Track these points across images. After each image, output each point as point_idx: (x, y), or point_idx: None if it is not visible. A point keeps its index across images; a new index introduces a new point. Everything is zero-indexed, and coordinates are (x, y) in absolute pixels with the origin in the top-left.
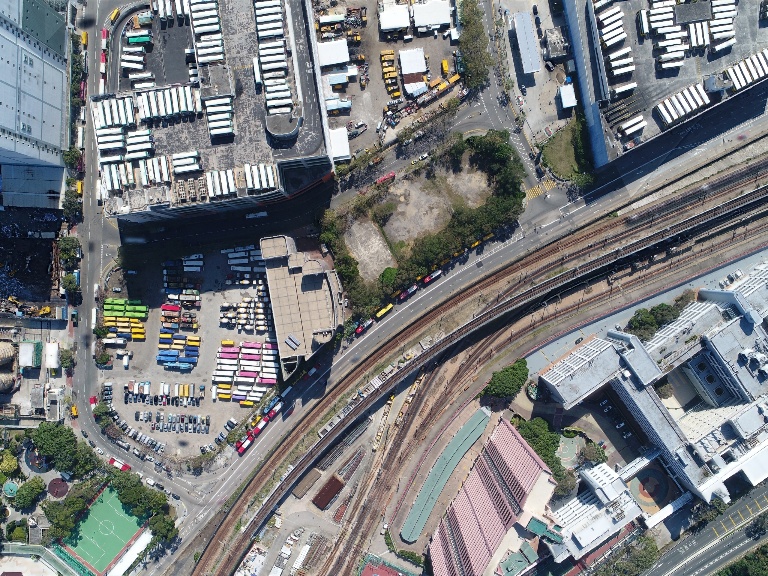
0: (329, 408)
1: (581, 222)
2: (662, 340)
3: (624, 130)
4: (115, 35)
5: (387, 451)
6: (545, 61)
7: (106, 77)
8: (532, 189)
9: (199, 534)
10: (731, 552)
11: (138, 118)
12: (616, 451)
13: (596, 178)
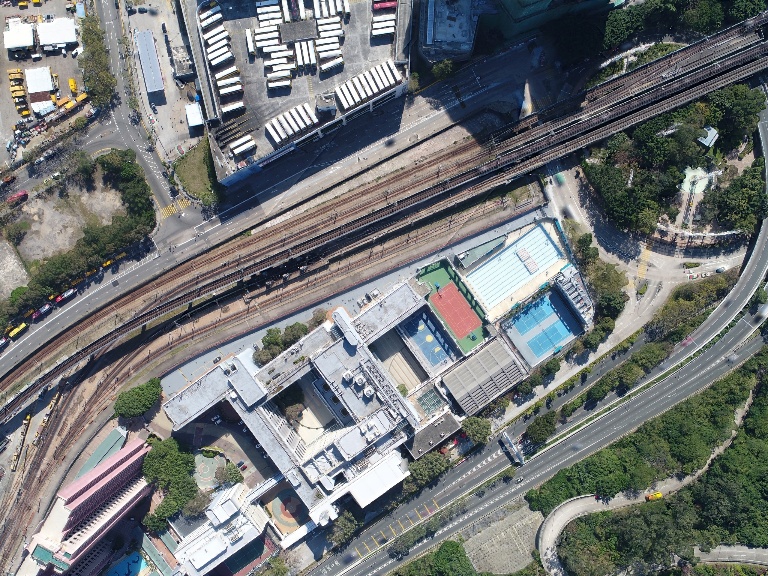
0: None
1: (217, 241)
2: (271, 361)
3: (233, 149)
4: None
5: (27, 471)
6: (176, 79)
7: None
8: (166, 208)
9: None
10: (374, 573)
11: None
12: (257, 471)
13: (221, 197)
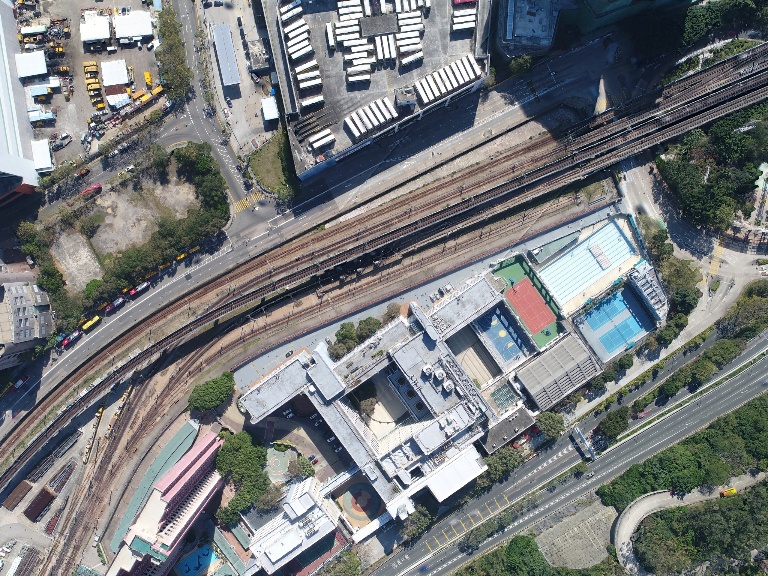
0: (39, 420)
1: (290, 235)
2: (349, 355)
3: (312, 143)
4: None
5: (98, 463)
6: (251, 73)
7: None
8: (240, 201)
9: None
10: (444, 567)
11: None
12: (328, 465)
13: (297, 191)
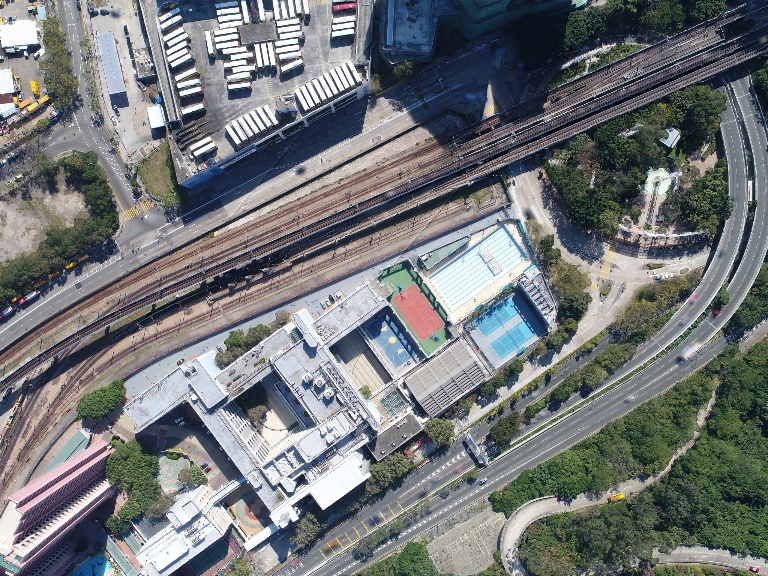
0: None
1: (180, 243)
2: (232, 363)
3: (193, 151)
4: None
5: None
6: (138, 81)
7: None
8: (129, 210)
9: None
10: (339, 574)
11: None
12: (221, 473)
13: (183, 199)
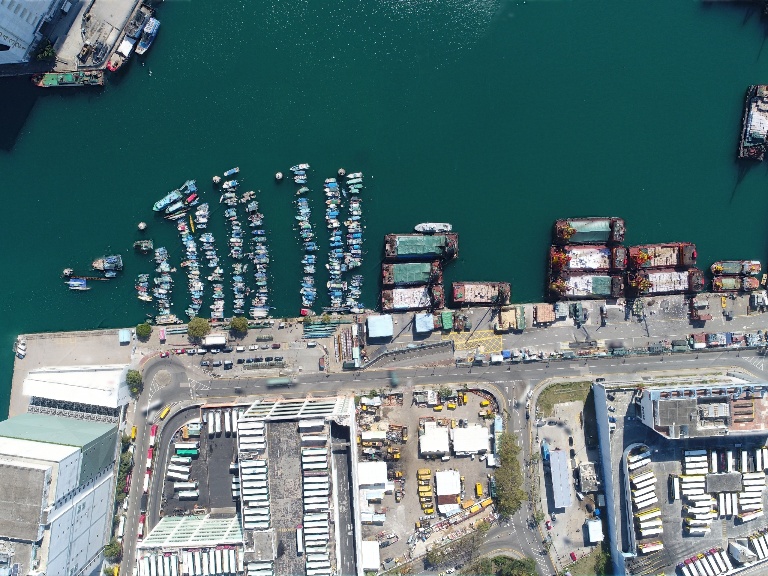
0: None
1: None
2: None
3: None
4: (163, 433)
5: None
6: (576, 490)
7: (151, 468)
8: None
9: None
10: None
11: (181, 569)
12: None
13: None
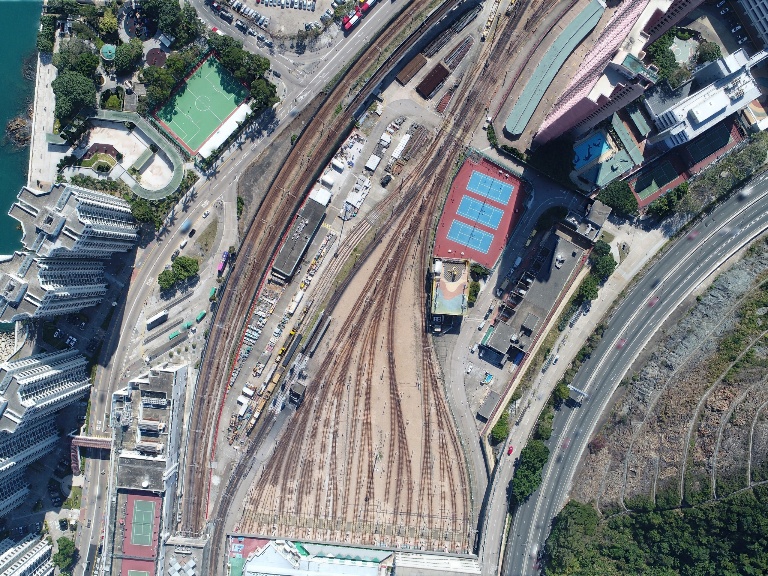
0: None
1: None
2: None
3: None
4: None
5: (496, 42)
6: None
7: None
8: None
9: (298, 116)
10: None
11: None
12: None
13: None
